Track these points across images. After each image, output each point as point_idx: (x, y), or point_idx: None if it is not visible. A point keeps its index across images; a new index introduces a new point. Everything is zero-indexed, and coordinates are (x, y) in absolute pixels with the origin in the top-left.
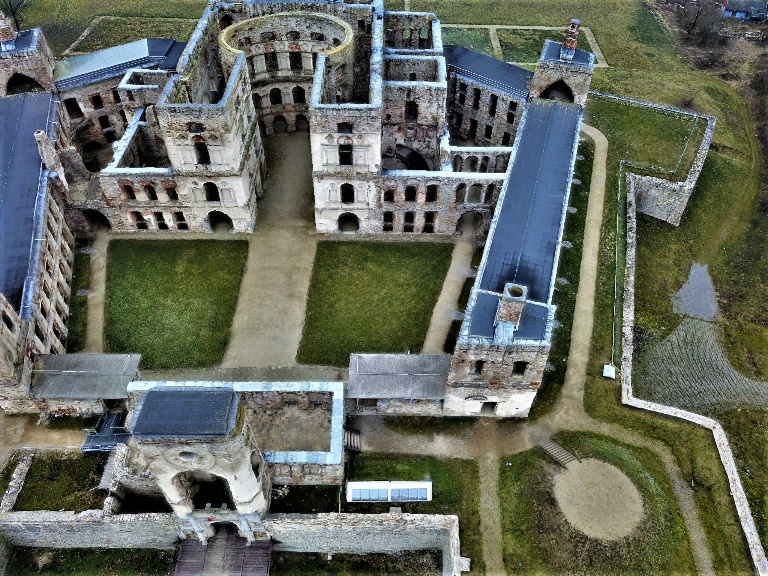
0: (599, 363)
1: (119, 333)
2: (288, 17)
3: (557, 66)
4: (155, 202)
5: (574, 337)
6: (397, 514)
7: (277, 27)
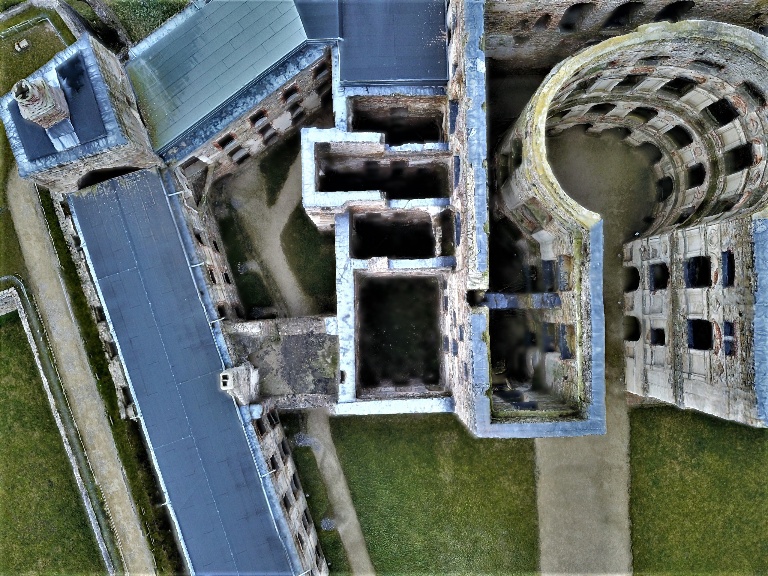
0: None
1: None
2: (665, 41)
3: None
4: None
5: None
6: None
7: (628, 54)
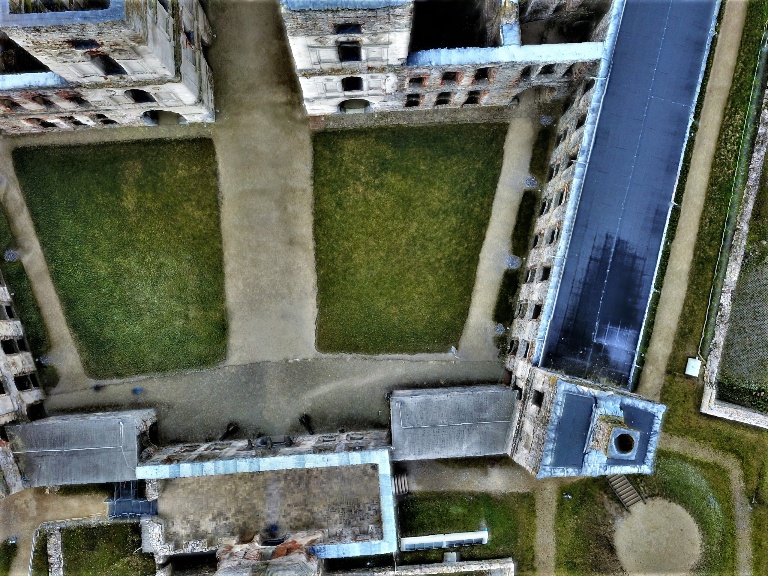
0: (683, 354)
1: (86, 322)
2: None
3: None
4: (57, 108)
5: (659, 317)
6: (453, 569)
7: None
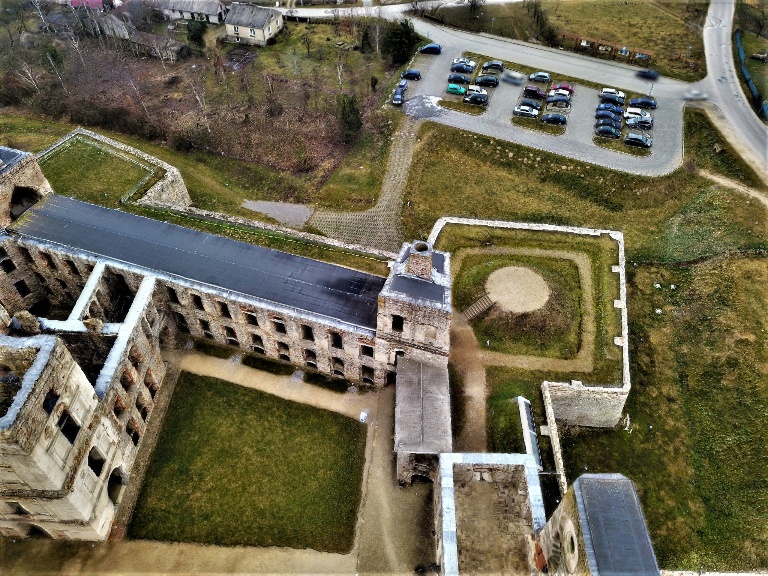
0: (384, 270)
1: None
2: None
3: (1, 179)
4: None
5: None
6: (552, 425)
7: None
